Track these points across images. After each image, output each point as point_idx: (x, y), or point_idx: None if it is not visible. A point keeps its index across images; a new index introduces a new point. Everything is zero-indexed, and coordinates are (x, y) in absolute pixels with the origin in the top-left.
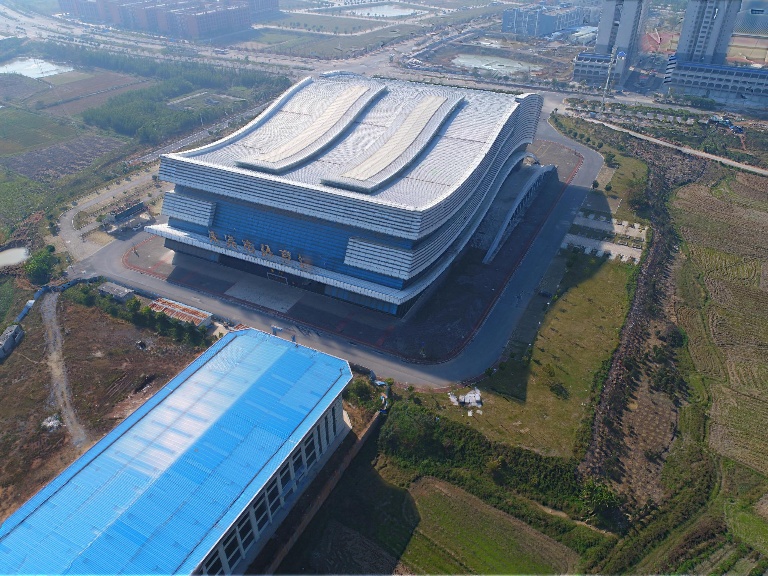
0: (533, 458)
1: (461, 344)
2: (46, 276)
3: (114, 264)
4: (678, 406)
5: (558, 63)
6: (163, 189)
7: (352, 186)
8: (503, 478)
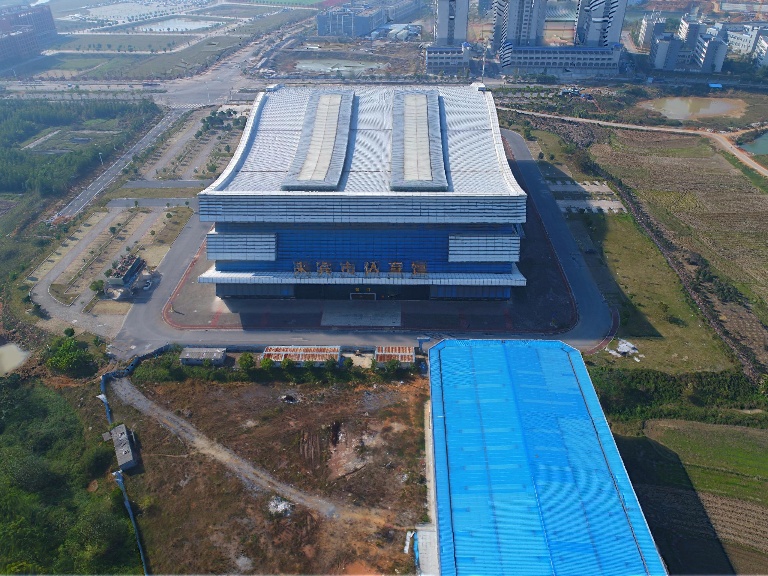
0: (712, 376)
1: (573, 308)
2: (88, 365)
3: (162, 330)
4: (748, 309)
5: (396, 59)
6: (130, 240)
7: (428, 187)
8: (700, 400)
